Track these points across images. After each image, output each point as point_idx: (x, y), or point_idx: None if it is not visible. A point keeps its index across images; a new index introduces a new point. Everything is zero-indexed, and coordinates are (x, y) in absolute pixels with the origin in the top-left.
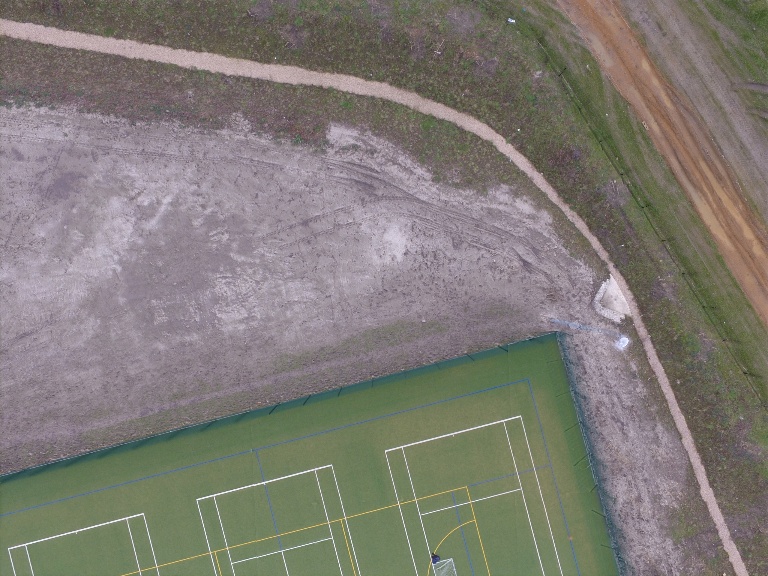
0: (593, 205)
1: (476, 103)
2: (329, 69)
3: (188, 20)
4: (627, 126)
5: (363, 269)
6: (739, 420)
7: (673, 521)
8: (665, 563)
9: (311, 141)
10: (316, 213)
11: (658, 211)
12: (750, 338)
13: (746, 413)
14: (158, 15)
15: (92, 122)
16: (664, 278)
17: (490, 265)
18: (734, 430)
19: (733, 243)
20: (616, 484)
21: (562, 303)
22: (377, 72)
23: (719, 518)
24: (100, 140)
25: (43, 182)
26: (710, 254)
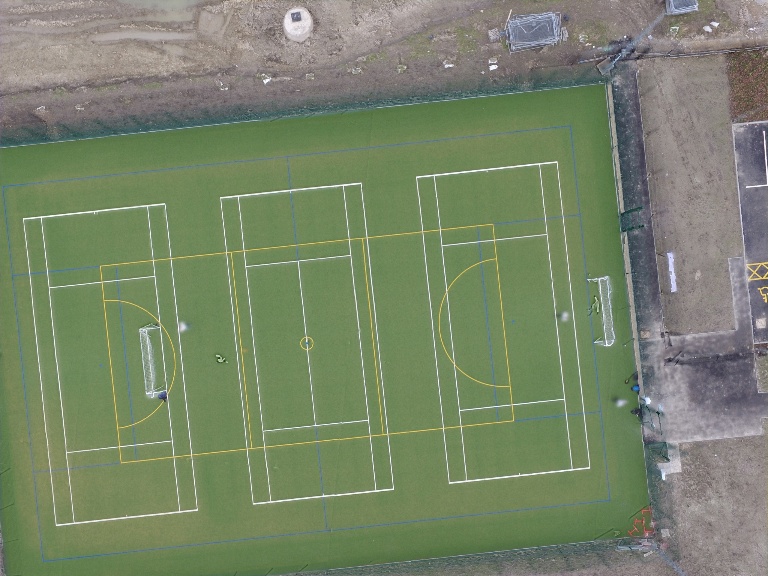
0: None
1: None
2: None
3: None
4: None
5: None
6: None
7: None
8: None
9: None
10: None
11: None
12: None
13: None
14: None
15: None
16: None
17: None
18: None
19: None
20: None
21: None
22: None
23: None
24: None
25: None
26: None
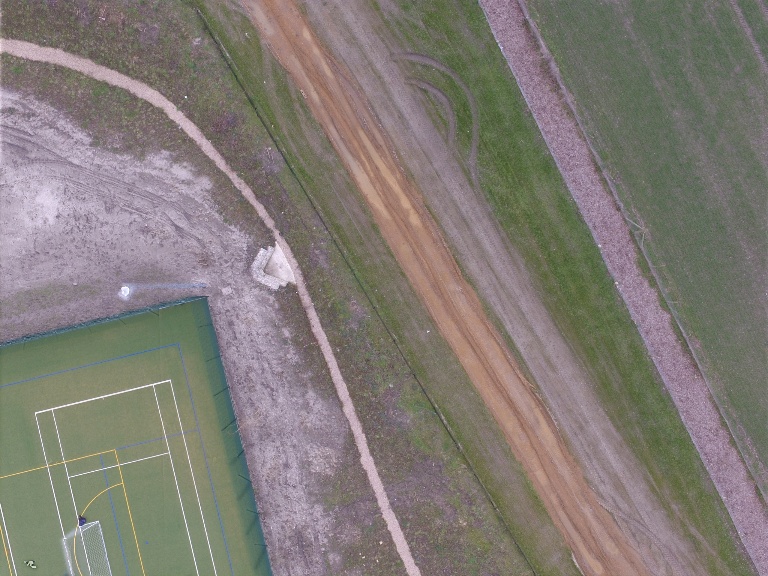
0: (253, 172)
1: (146, 70)
2: (3, 34)
3: None
4: (285, 94)
5: (15, 231)
6: (388, 388)
7: (326, 488)
8: (312, 529)
9: None
10: None
11: (313, 179)
12: (402, 306)
13: (396, 381)
14: None
15: None
16: (317, 245)
17: (142, 229)
18: (382, 397)
19: (389, 212)
20: (264, 449)
21: (214, 268)
22: (50, 38)
23: (379, 486)
24: None
25: None
26: (365, 222)
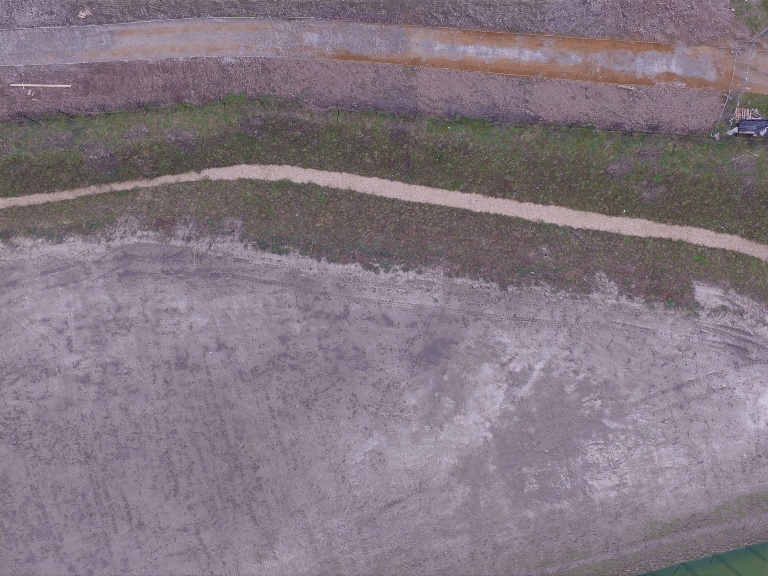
0: None
1: None
2: (679, 222)
3: (540, 175)
4: None
5: (737, 434)
6: None
7: None
8: None
9: (684, 304)
10: (689, 378)
11: None
12: None
13: None
14: (510, 170)
15: (462, 287)
16: None
17: None
18: None
19: None
20: None
21: None
22: (729, 225)
23: None
24: (471, 305)
25: (413, 348)
26: None
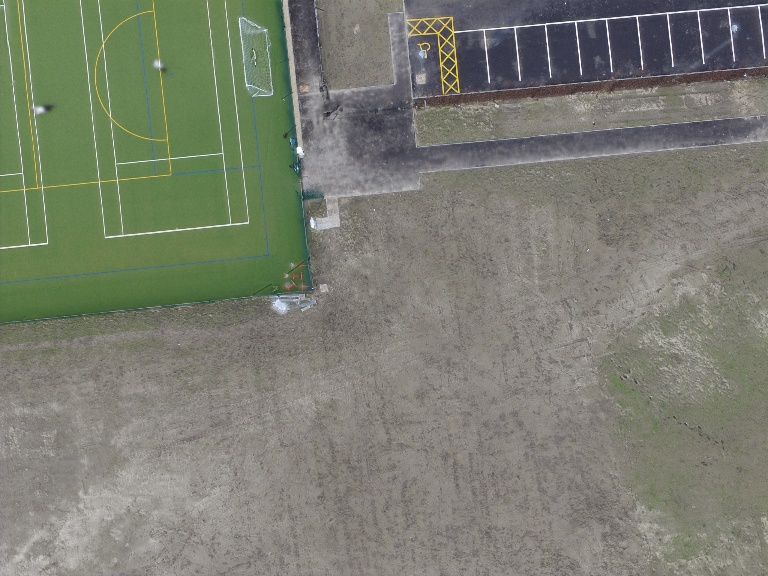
0: None
1: None
2: None
3: None
4: None
5: None
6: None
7: None
8: None
9: None
10: None
11: None
12: None
13: None
14: None
15: None
16: None
17: None
18: None
19: None
20: None
21: None
22: None
23: None
24: None
25: None
26: None
